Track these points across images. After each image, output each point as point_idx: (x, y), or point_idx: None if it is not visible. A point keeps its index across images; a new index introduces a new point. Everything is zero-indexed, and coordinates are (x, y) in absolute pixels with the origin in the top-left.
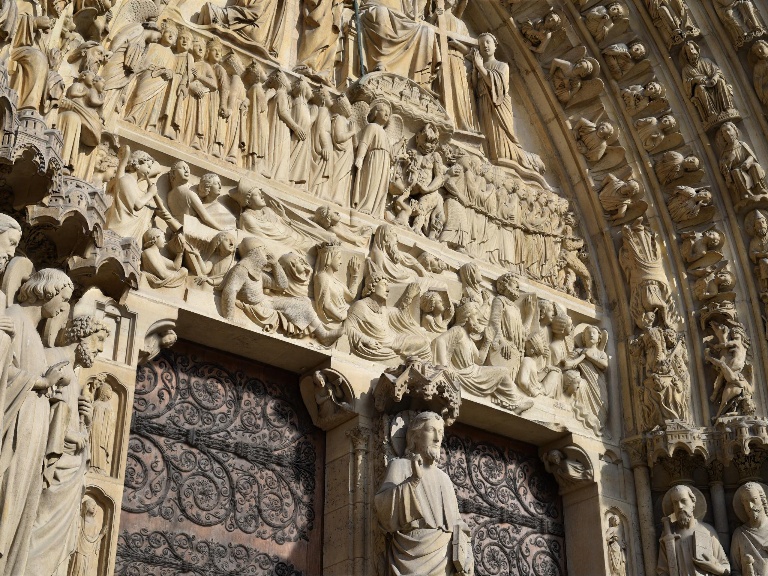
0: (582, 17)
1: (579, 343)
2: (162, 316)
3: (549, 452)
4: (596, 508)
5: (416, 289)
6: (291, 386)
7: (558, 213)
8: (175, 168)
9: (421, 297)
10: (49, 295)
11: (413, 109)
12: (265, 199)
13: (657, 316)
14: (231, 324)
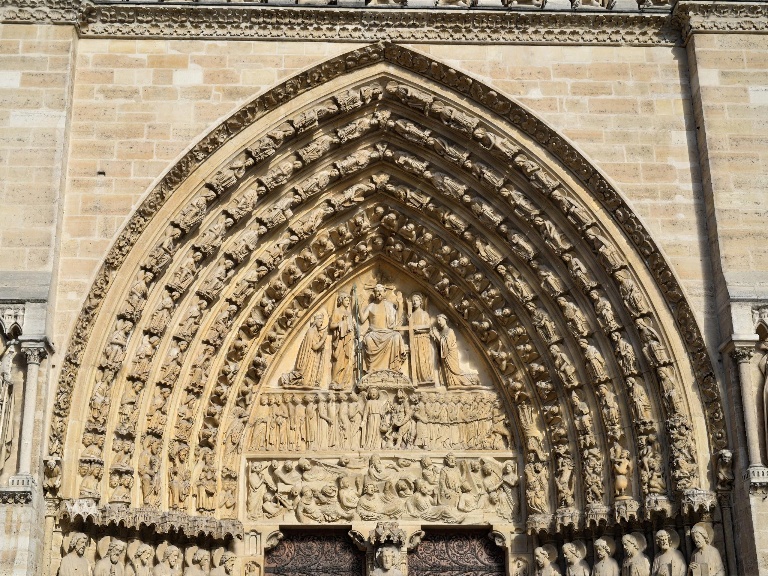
0: None
1: (506, 472)
2: (273, 531)
3: None
4: (508, 560)
5: (389, 483)
6: None
7: (490, 402)
8: (271, 464)
9: None
10: None
11: (390, 385)
12: (314, 462)
13: None
14: (303, 524)
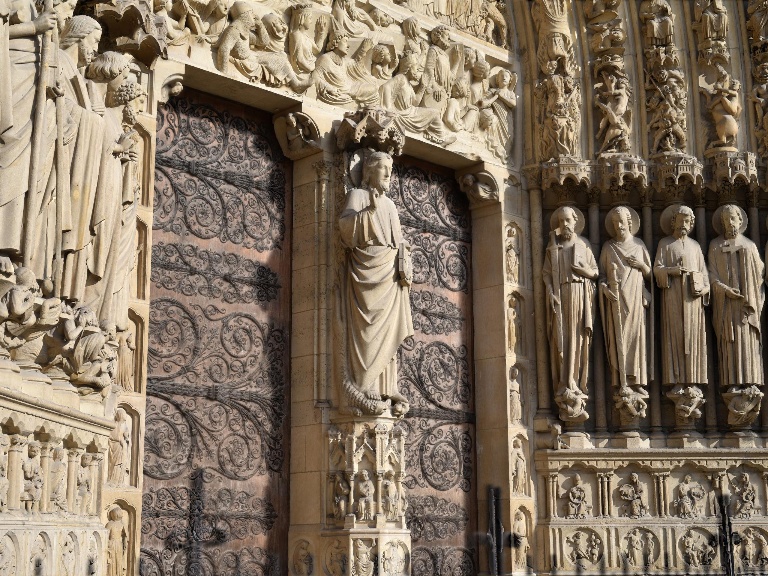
0: None
1: (493, 84)
2: (173, 71)
3: (464, 176)
4: (499, 222)
5: (370, 44)
6: (266, 123)
7: None
8: None
9: (373, 49)
10: (114, 75)
11: None
12: None
13: (559, 64)
14: (225, 76)
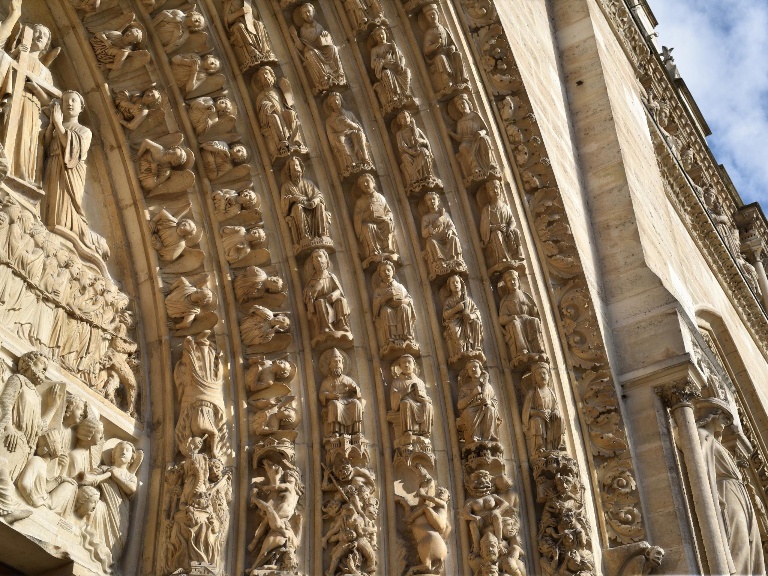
0: (186, 104)
1: (107, 460)
2: None
3: None
4: None
5: None
6: None
7: (114, 308)
8: None
9: None
10: None
11: None
12: None
13: (205, 444)
14: None
